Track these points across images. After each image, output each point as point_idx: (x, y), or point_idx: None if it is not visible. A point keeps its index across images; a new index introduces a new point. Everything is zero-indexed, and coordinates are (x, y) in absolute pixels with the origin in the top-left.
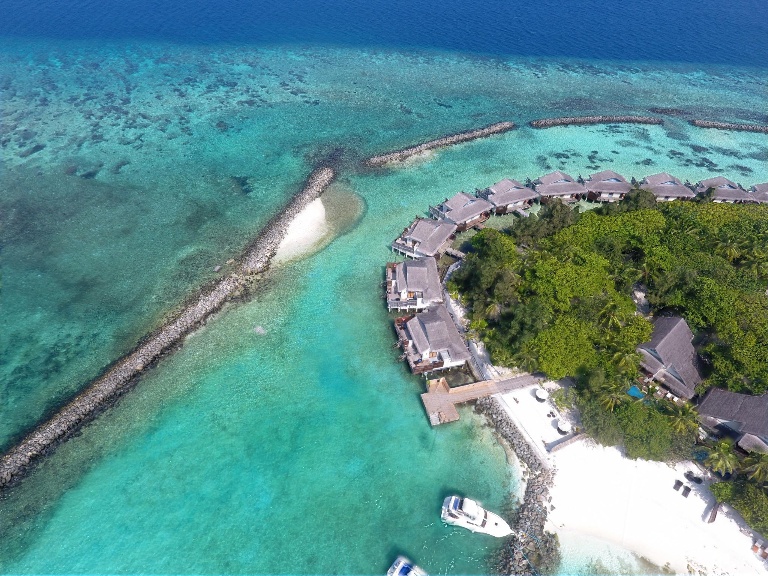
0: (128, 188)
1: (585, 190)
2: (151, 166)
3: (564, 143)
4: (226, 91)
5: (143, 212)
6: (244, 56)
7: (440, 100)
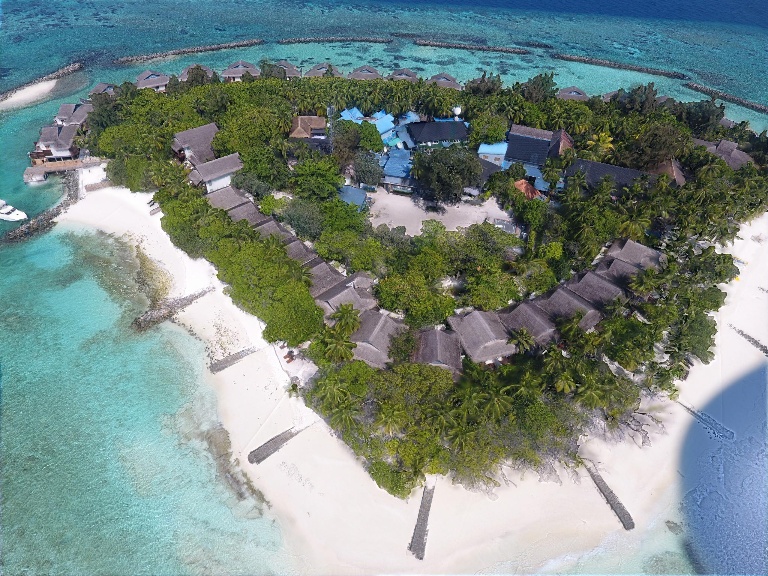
0: None
1: (258, 74)
2: None
3: (292, 53)
4: (41, 18)
5: None
6: None
7: (220, 26)
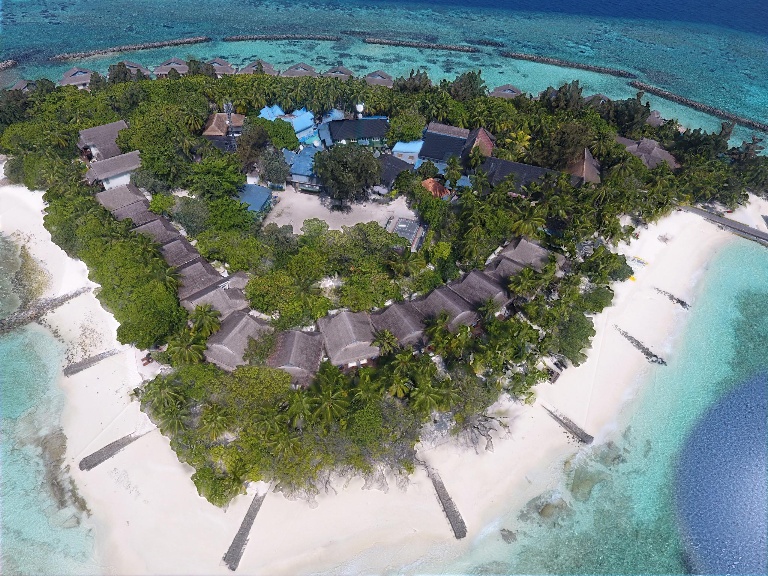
0: None
1: None
2: None
3: (236, 50)
4: None
5: None
6: None
7: (169, 23)
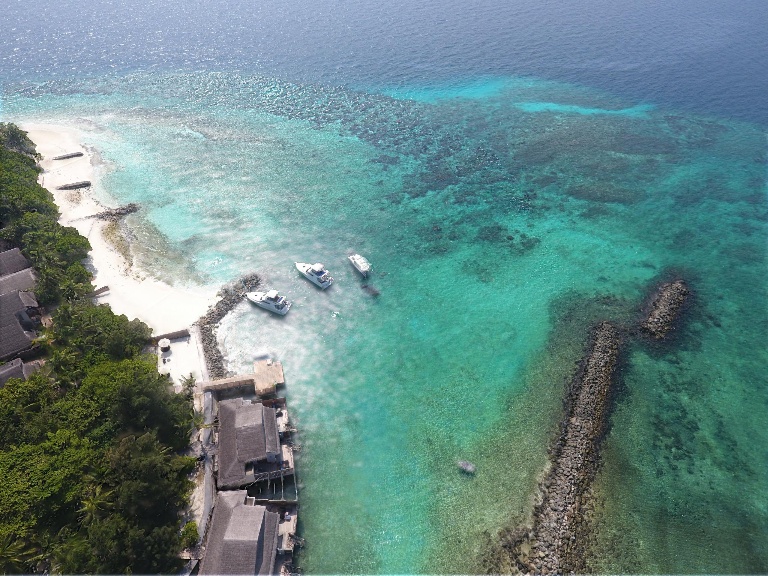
0: None
1: None
2: None
3: None
4: None
5: None
6: None
7: None
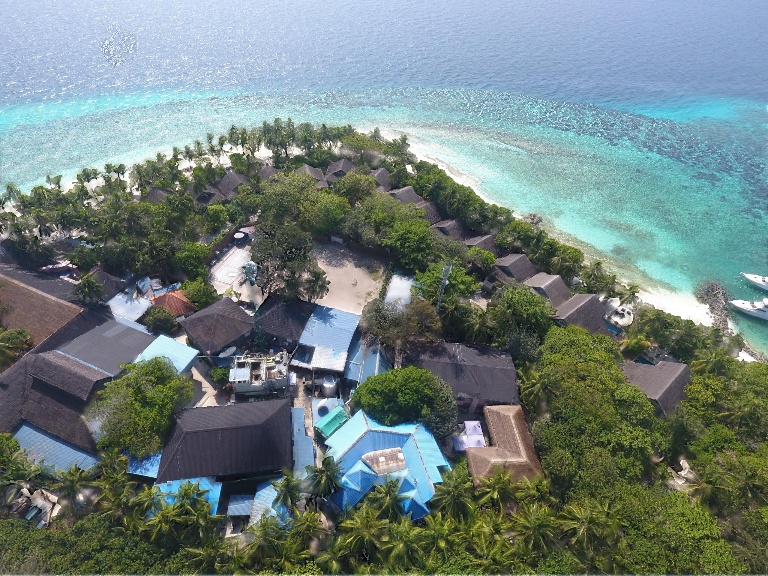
0: None
1: None
2: None
3: None
4: None
5: None
6: None
7: None
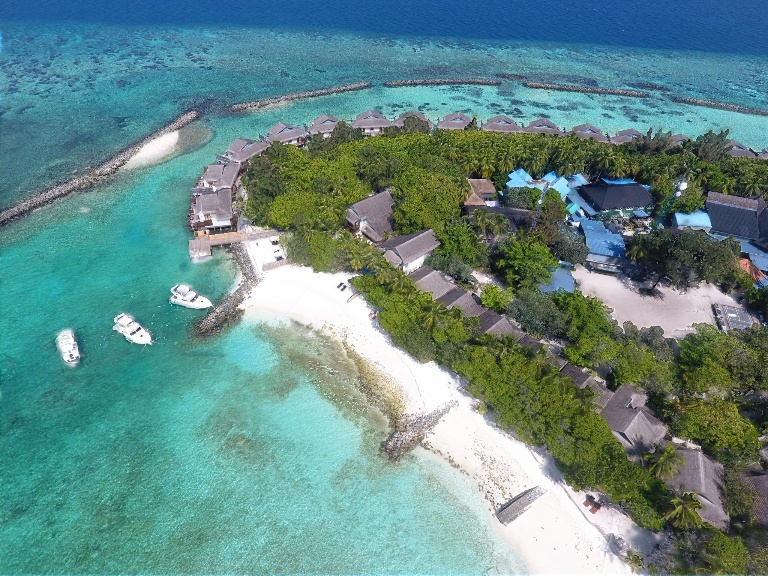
0: (25, 123)
1: (390, 124)
2: (50, 109)
3: (405, 97)
4: (136, 59)
5: (32, 138)
6: (164, 33)
7: (318, 67)
